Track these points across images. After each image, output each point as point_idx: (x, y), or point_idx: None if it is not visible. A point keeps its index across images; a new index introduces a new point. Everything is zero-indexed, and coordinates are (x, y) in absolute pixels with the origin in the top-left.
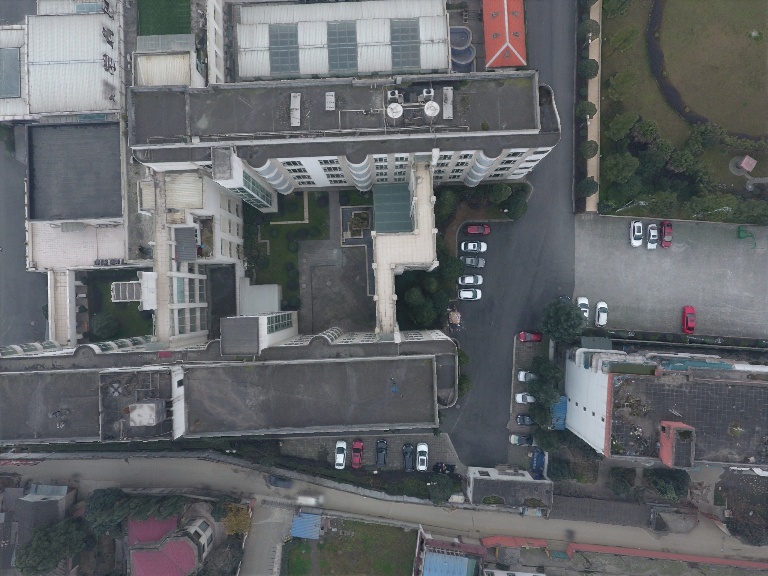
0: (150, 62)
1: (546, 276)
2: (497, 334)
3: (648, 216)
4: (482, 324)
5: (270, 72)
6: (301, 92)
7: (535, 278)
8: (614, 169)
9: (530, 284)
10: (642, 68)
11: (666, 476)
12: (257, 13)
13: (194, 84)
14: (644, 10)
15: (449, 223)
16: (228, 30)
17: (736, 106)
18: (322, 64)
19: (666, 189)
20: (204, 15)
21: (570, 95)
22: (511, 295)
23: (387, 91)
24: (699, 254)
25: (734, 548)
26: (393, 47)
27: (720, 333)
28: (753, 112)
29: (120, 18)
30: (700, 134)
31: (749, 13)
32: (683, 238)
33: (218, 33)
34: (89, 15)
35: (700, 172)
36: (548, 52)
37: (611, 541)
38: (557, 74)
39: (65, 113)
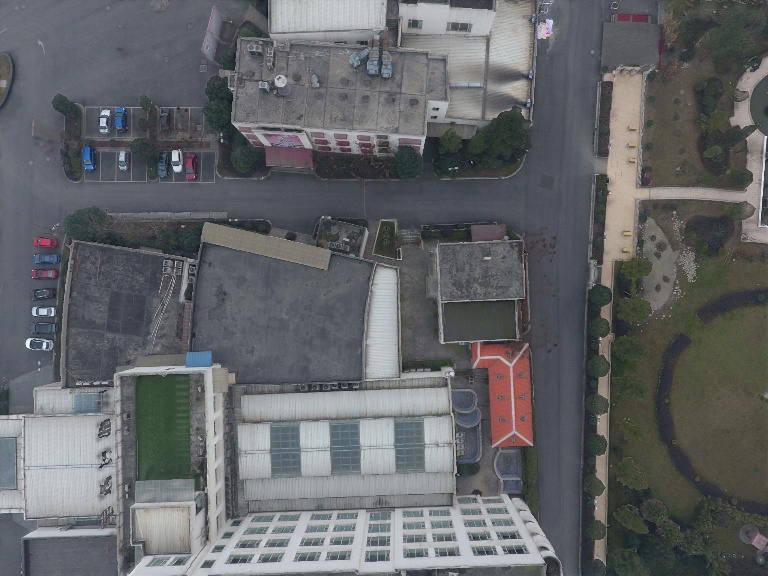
0: (148, 514)
1: None
2: None
3: None
4: None
5: (271, 474)
6: (303, 575)
7: None
8: (622, 569)
9: None
10: (651, 432)
11: None
12: (258, 402)
13: (193, 539)
14: (654, 371)
15: None
16: (229, 413)
17: (747, 471)
18: (324, 467)
19: None
20: (204, 439)
21: (577, 459)
22: None
23: (391, 575)
24: None
25: None
26: (397, 450)
27: None
28: (764, 478)
29: (118, 448)
30: (710, 511)
31: (761, 375)
32: None
33: (218, 440)
34: (87, 416)
35: (710, 558)
36: (555, 415)
37: None
38: (564, 438)
39: (62, 518)
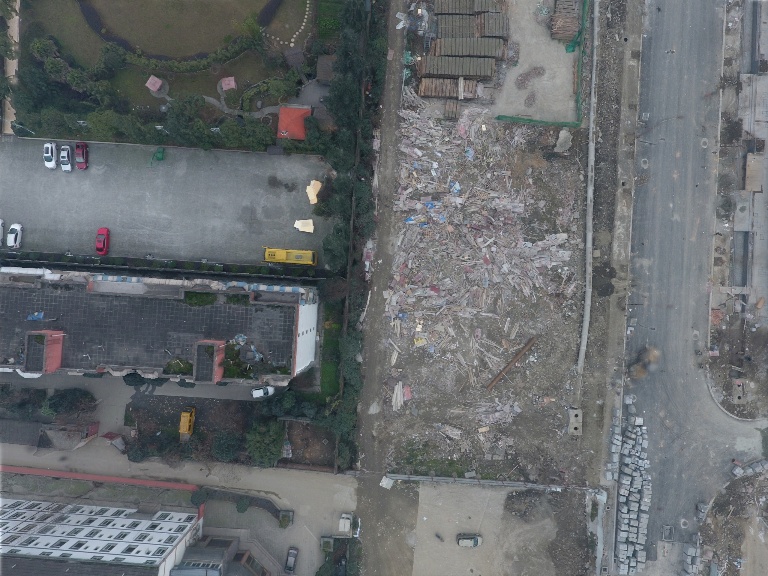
0: None
1: None
2: None
3: (67, 138)
4: None
5: None
6: None
7: None
8: None
9: None
10: None
11: (61, 395)
12: None
13: None
14: None
15: None
16: None
17: (159, 28)
18: None
19: (78, 110)
20: None
21: None
22: None
23: None
24: (118, 176)
25: (141, 468)
26: None
27: (137, 255)
28: (175, 34)
29: None
30: None
31: None
32: (103, 160)
33: None
34: None
35: (93, 91)
36: None
37: (21, 461)
38: None
39: None
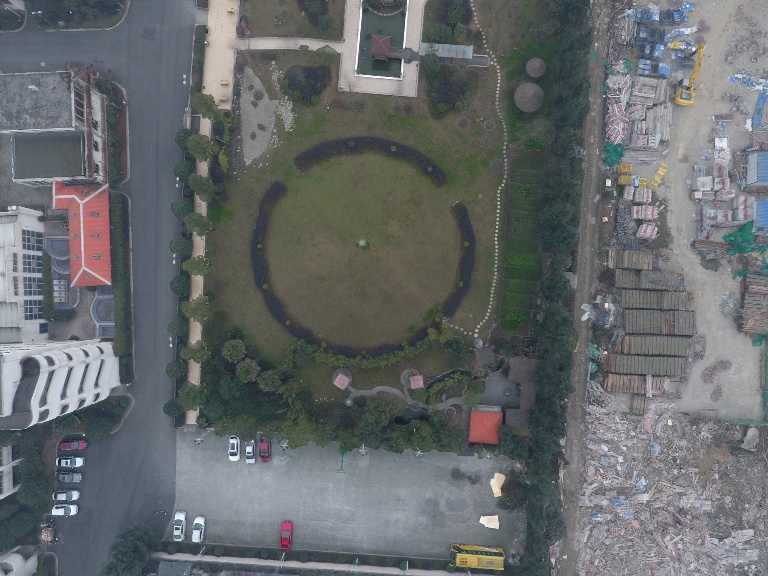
0: None
1: (146, 489)
2: (95, 548)
3: None
4: (81, 538)
5: None
6: None
7: (134, 492)
8: None
9: (129, 498)
10: (247, 278)
11: None
12: None
13: None
14: (250, 219)
15: (46, 437)
16: None
17: (341, 317)
18: None
19: (263, 405)
20: None
21: (174, 305)
22: (110, 509)
23: None
24: (301, 467)
25: None
26: None
27: (320, 547)
28: (358, 323)
29: None
30: (293, 352)
31: (357, 222)
32: (285, 451)
33: None
34: None
35: (284, 395)
36: (153, 261)
37: None
38: (161, 284)
39: None
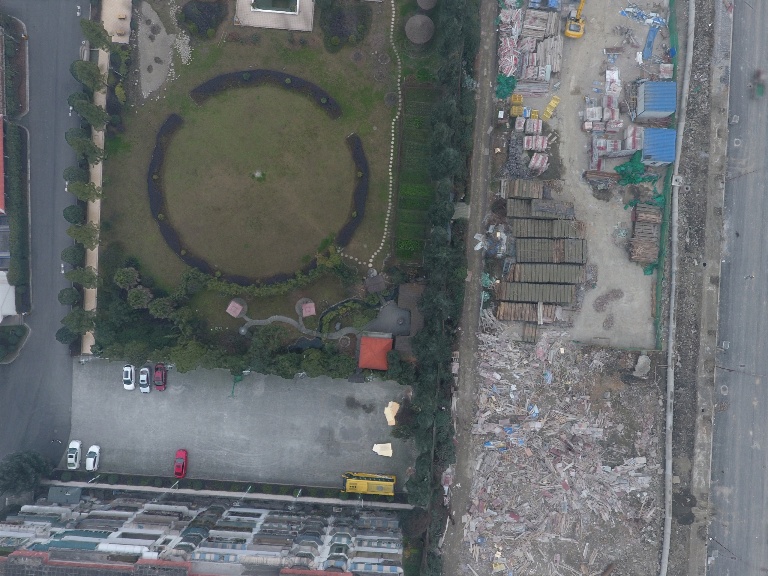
0: None
1: (42, 419)
2: None
3: None
4: None
5: None
6: None
7: (30, 421)
8: None
9: (25, 427)
10: (144, 209)
11: None
12: None
13: None
14: (148, 151)
15: None
16: None
17: (237, 247)
18: None
19: None
20: None
21: None
22: (6, 438)
23: None
24: (196, 397)
25: None
26: None
27: (215, 476)
28: (254, 254)
29: None
30: (186, 280)
31: (253, 154)
32: (181, 380)
33: None
34: None
35: (175, 321)
36: (51, 193)
37: None
38: (58, 215)
39: None
